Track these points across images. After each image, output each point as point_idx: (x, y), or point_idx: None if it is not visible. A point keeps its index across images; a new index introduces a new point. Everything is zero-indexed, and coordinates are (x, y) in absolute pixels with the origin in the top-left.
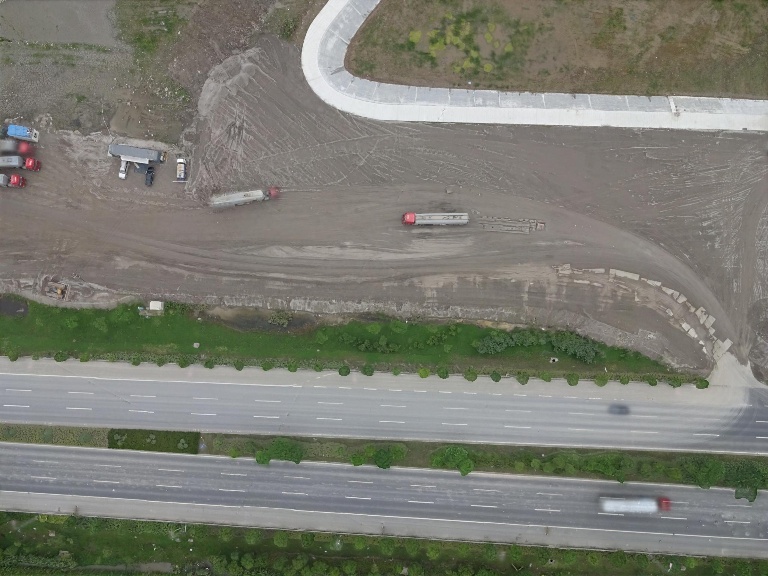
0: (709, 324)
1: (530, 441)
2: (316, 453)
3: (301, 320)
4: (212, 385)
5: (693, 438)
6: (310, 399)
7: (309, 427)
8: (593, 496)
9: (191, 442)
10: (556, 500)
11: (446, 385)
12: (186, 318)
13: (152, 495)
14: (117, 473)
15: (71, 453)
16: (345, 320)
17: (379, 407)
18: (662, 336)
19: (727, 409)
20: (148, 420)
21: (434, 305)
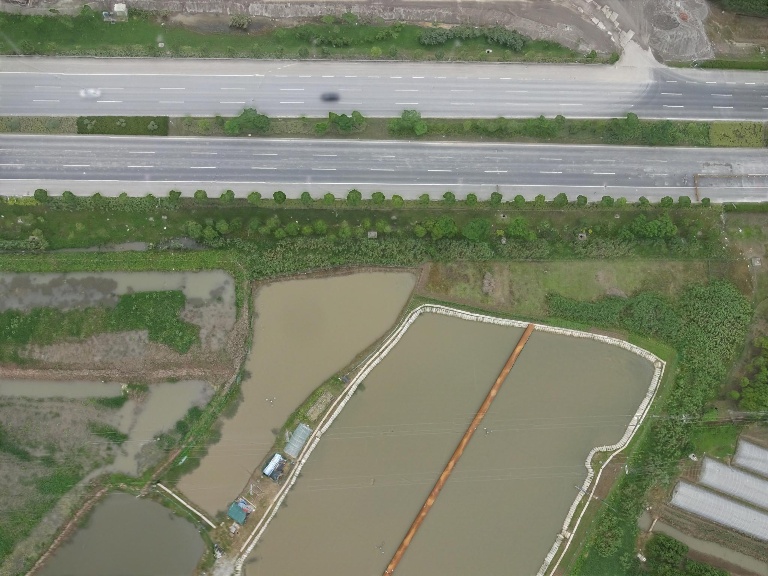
0: (614, 18)
1: (475, 115)
2: (282, 130)
3: (260, 24)
4: (178, 77)
5: (612, 108)
6: (273, 86)
7: (274, 110)
8: (534, 158)
9: (161, 124)
10: (502, 163)
11: (396, 71)
12: (150, 23)
13: (124, 175)
14: (87, 157)
15: (39, 141)
16: (300, 23)
17: (337, 91)
18: (577, 28)
19: (637, 84)
20: (117, 109)
21: (380, 7)
